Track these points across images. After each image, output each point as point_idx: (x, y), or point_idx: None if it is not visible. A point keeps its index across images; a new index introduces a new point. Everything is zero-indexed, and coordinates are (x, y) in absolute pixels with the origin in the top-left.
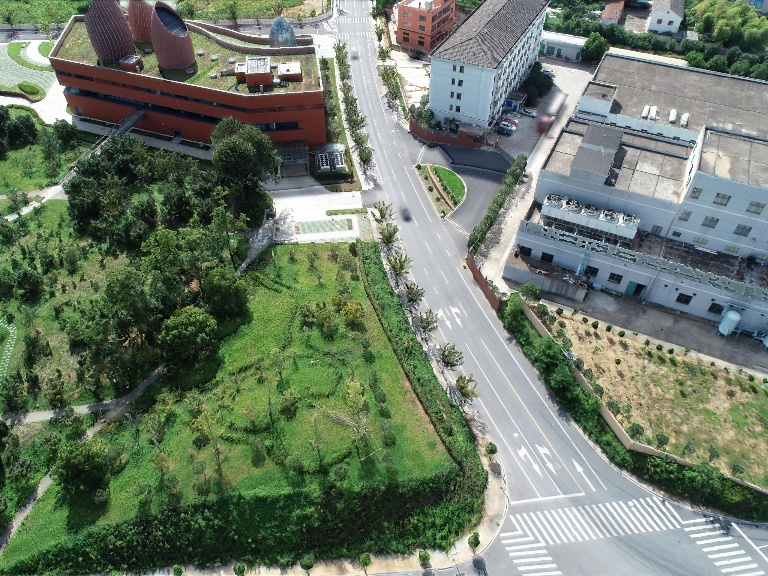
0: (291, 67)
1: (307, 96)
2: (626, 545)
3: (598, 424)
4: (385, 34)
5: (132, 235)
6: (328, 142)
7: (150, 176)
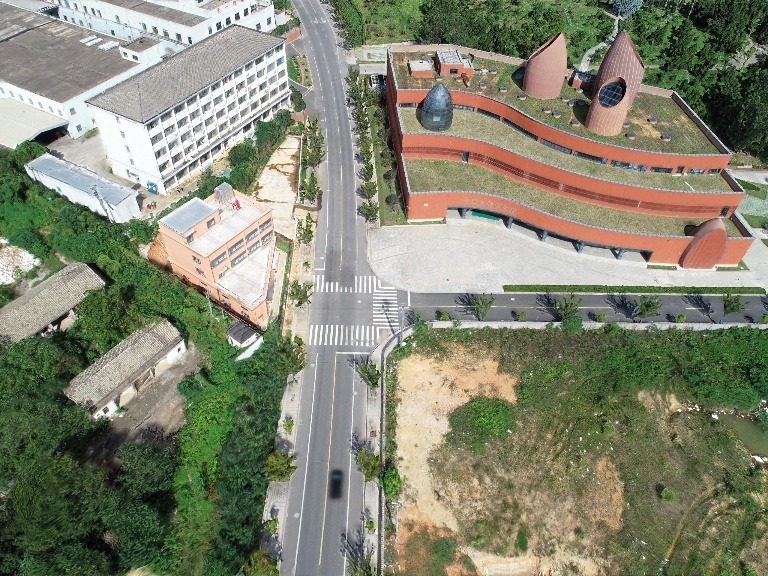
0: (419, 66)
1: (401, 49)
2: None
3: None
4: (292, 281)
5: None
6: None
7: None
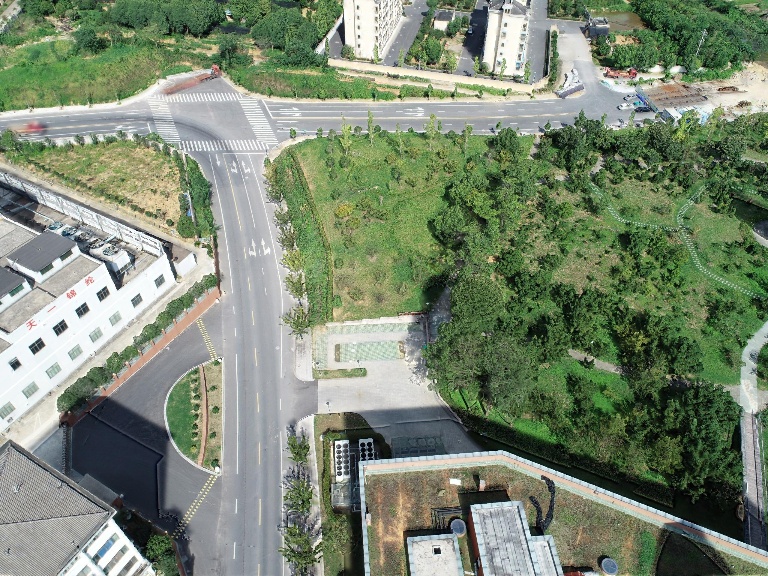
0: (432, 570)
1: None
2: (215, 138)
3: (193, 170)
4: None
5: (573, 286)
6: (360, 520)
7: (629, 426)
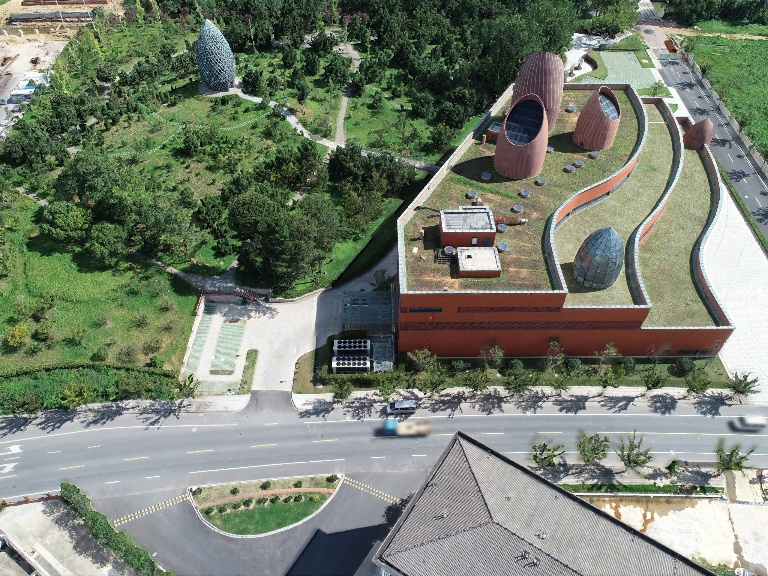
0: (482, 260)
1: None
2: None
3: None
4: None
5: None
6: (405, 353)
7: None
